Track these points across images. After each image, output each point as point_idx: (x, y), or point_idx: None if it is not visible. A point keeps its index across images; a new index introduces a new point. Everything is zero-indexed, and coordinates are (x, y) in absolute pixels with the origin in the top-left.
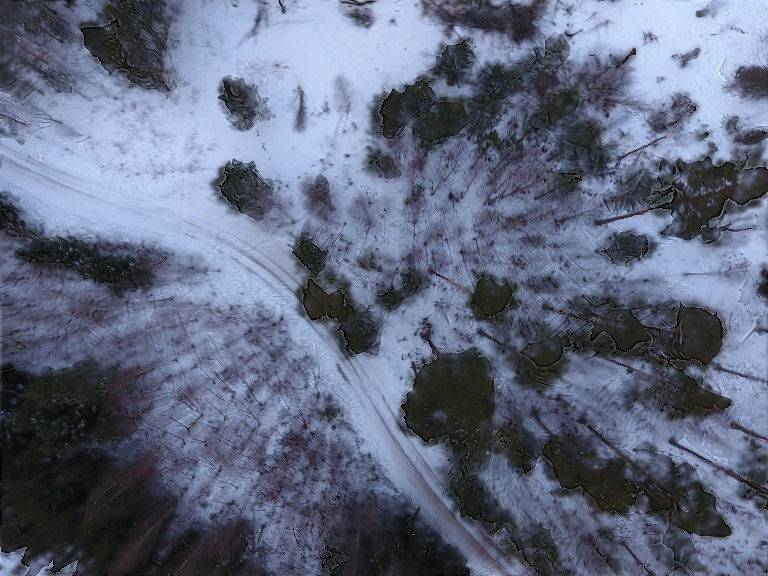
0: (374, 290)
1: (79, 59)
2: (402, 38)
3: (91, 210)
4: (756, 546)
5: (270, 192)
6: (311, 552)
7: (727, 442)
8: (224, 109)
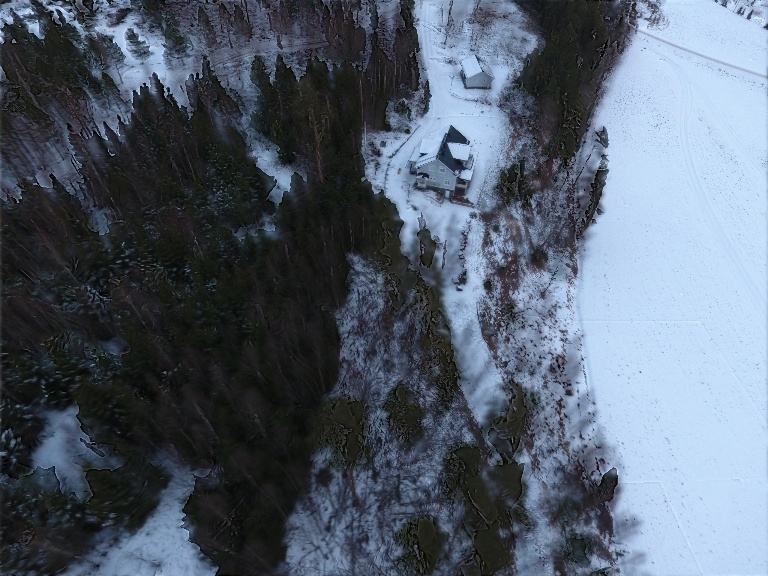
0: None
1: None
2: (122, 31)
3: (178, 104)
4: None
5: None
6: None
7: None
8: (137, 71)
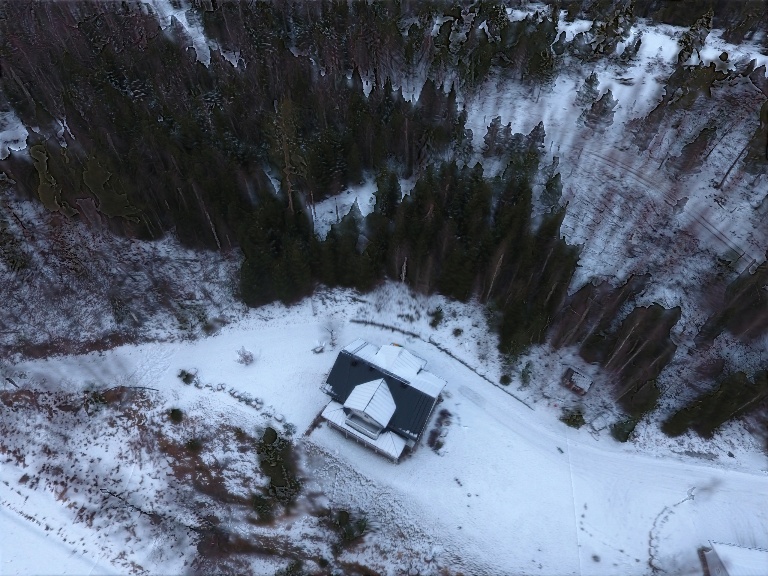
0: None
1: (489, 95)
2: (650, 88)
3: None
4: None
5: (613, 115)
6: (686, 320)
7: None
8: (565, 109)
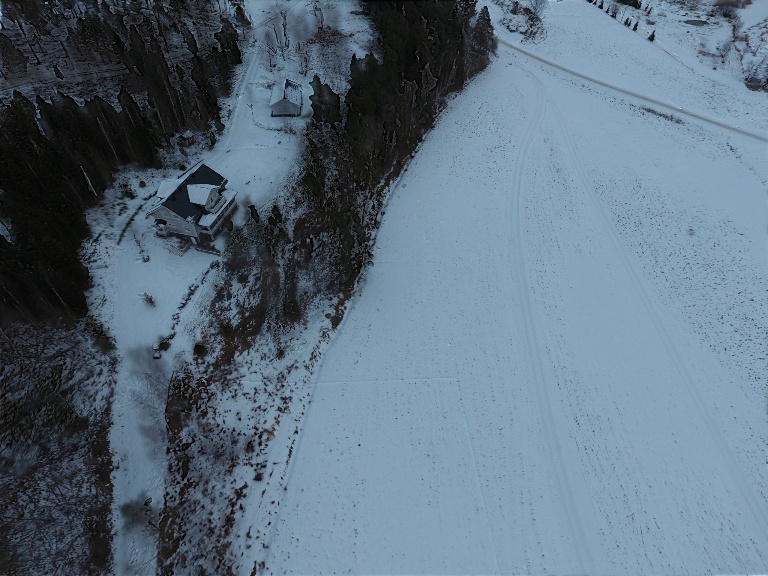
0: (8, 74)
1: None
2: None
3: None
4: None
5: None
6: None
7: None
8: None
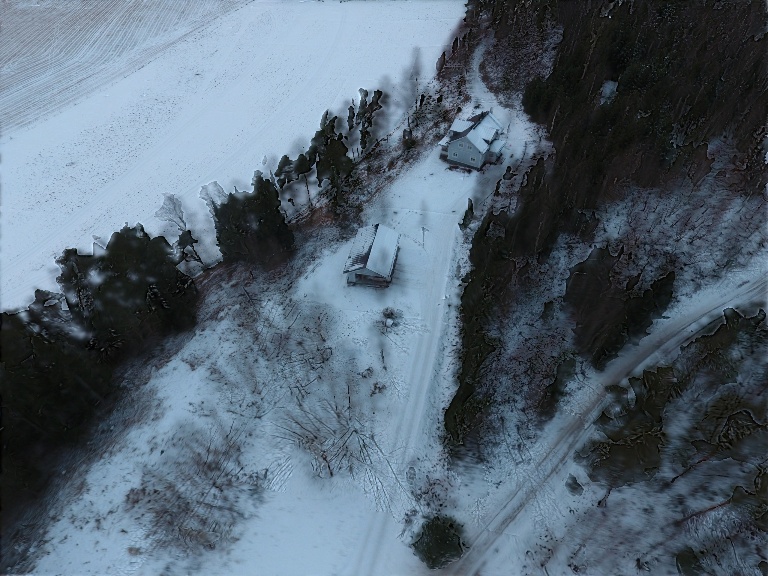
0: None
1: None
2: None
3: None
4: None
5: None
6: None
7: None
8: None
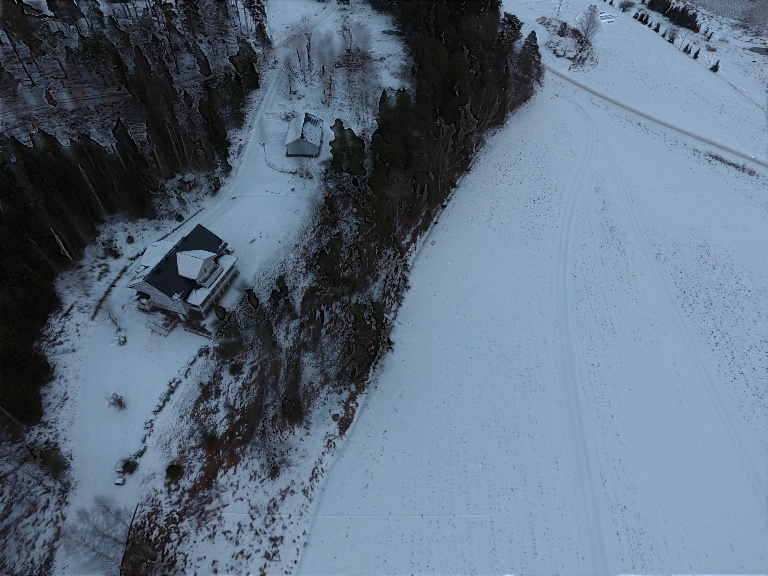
0: None
1: None
2: None
3: None
4: (182, 31)
5: None
6: None
7: (127, 30)
8: None
